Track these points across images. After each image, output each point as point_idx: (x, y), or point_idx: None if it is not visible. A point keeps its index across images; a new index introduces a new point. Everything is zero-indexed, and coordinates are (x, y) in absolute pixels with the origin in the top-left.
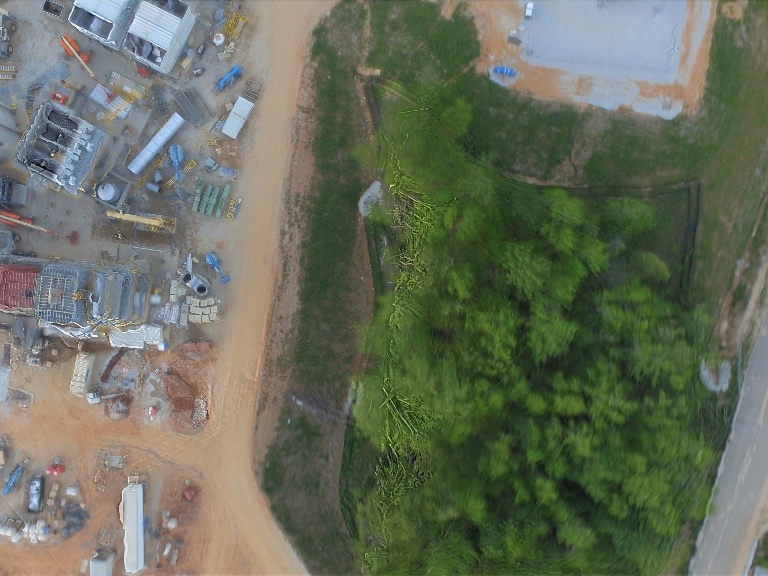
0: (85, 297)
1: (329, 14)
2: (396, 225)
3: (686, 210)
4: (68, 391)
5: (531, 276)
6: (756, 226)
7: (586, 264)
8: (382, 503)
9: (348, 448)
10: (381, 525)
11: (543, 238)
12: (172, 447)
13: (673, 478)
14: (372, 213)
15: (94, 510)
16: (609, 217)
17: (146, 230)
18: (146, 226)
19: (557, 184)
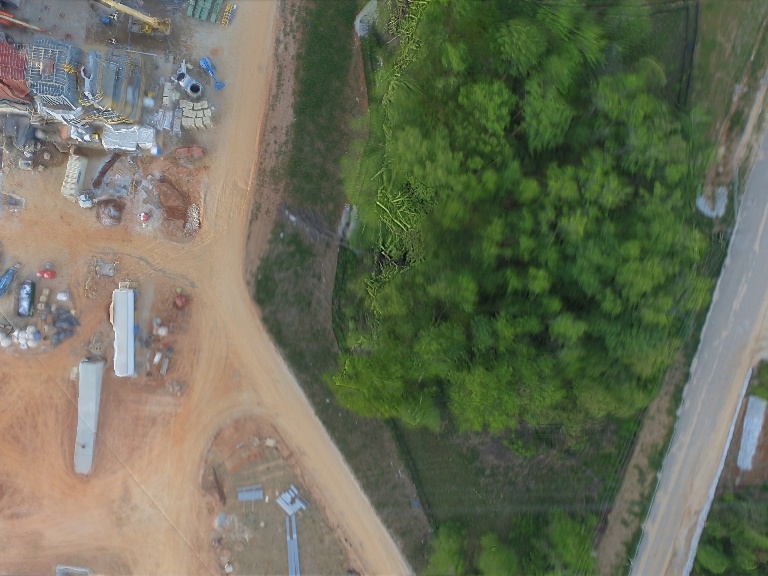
0: (77, 70)
1: None
2: (392, 38)
3: (684, 29)
4: (60, 196)
5: (526, 54)
6: (755, 50)
7: (582, 52)
8: (373, 282)
9: (341, 269)
10: (373, 333)
11: (539, 22)
12: (164, 255)
13: (667, 283)
14: (368, 33)
15: (84, 317)
16: (606, 31)
17: (140, 32)
18: (140, 27)
19: (555, 2)
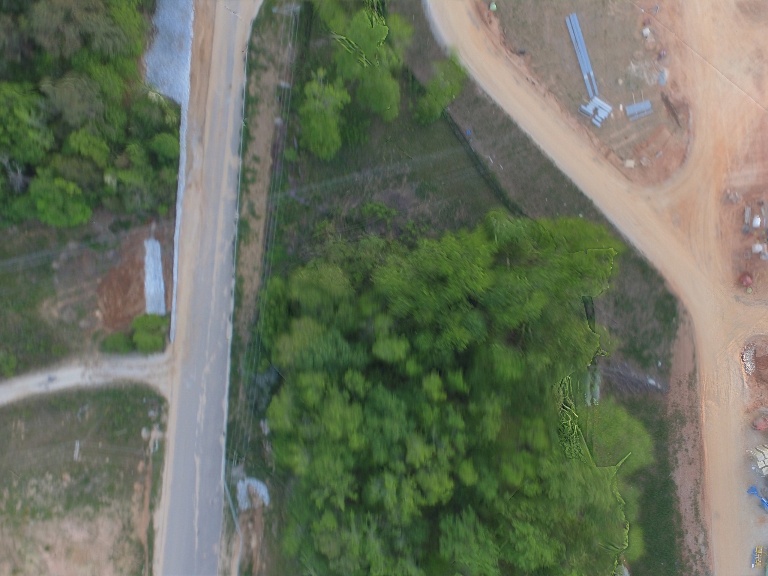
0: None
1: None
2: None
3: None
4: None
5: None
6: None
7: None
8: None
9: None
10: None
11: None
12: None
13: (298, 412)
14: None
15: None
16: None
17: None
18: None
19: None
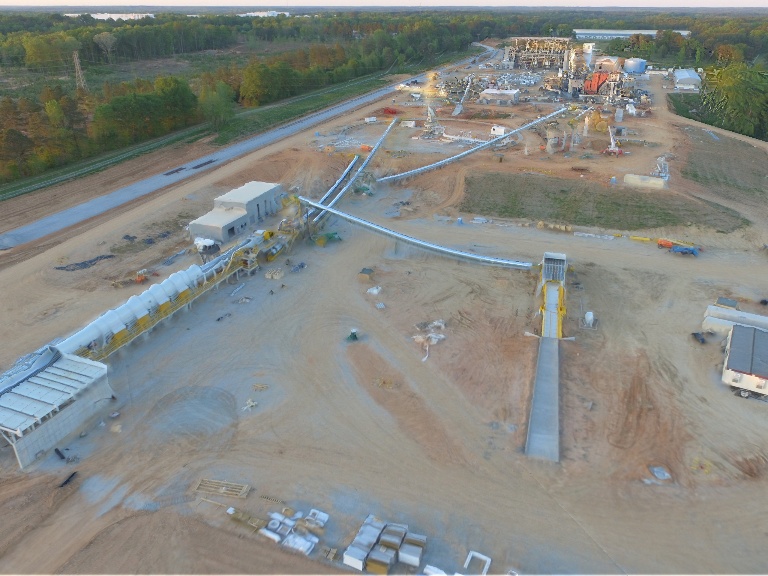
0: None
1: (671, 93)
2: None
3: None
4: None
5: None
6: None
7: None
8: None
9: None
10: None
11: None
12: None
13: None
14: None
15: None
16: None
17: None
18: None
19: None
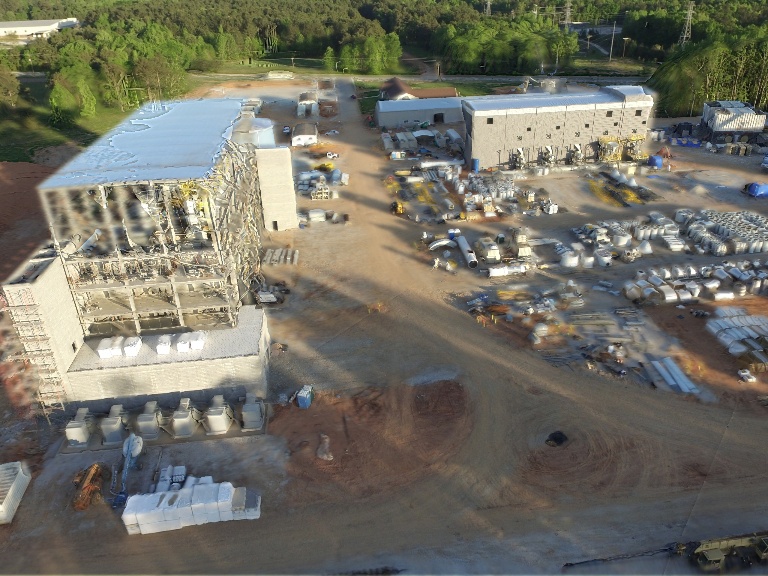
0: None
1: None
2: None
3: None
4: None
5: None
6: None
7: None
8: None
9: None
10: None
11: None
12: None
13: None
14: None
15: None
16: None
17: None
18: None
19: None
